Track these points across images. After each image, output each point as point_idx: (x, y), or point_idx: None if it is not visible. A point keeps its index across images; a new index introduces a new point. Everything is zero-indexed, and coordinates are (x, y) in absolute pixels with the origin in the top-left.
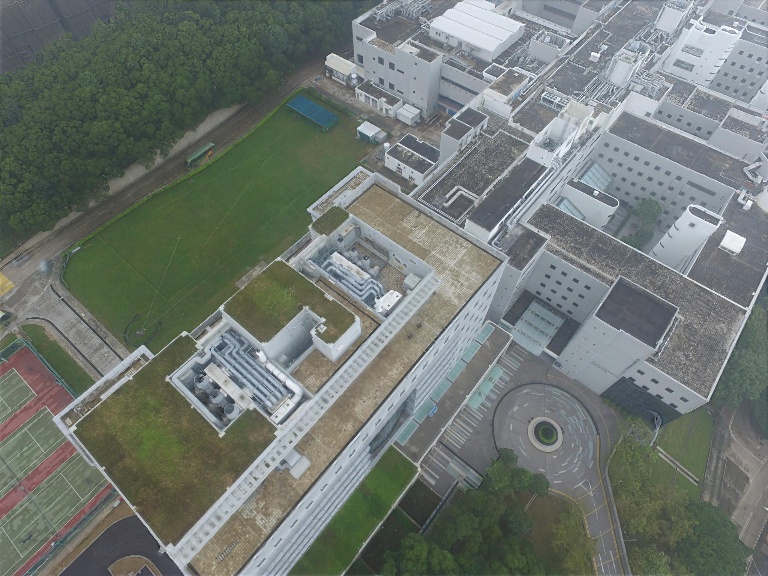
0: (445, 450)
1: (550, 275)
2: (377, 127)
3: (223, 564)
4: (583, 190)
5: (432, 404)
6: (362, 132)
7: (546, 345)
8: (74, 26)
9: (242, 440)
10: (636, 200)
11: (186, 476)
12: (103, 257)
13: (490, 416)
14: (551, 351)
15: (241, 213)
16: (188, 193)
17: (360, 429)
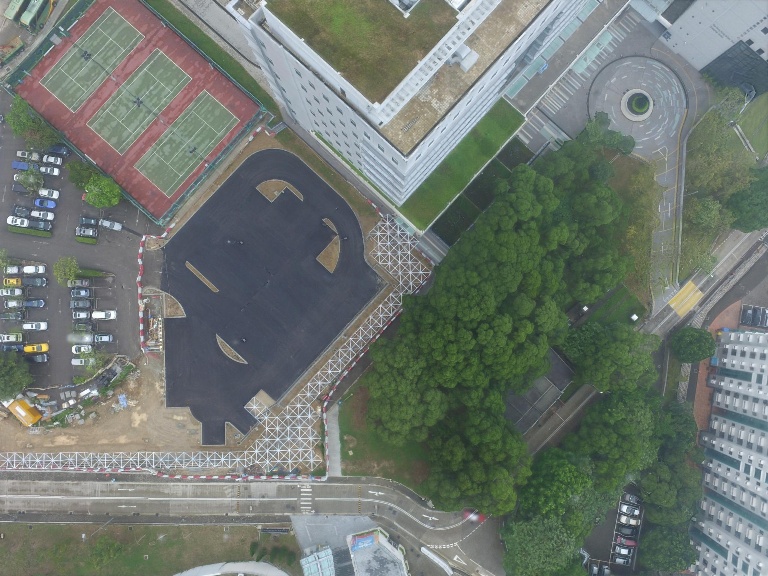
0: (541, 115)
1: None
2: None
3: (408, 134)
4: None
5: (542, 62)
6: None
7: (663, 11)
8: None
9: (427, 21)
10: None
11: (379, 50)
12: None
13: (588, 86)
14: (665, 19)
15: None
16: None
17: (522, 32)
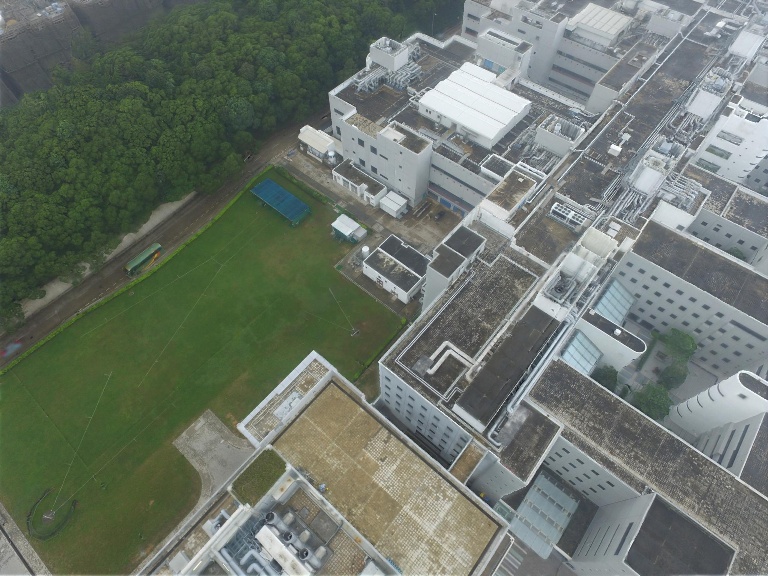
0: None
1: (562, 455)
2: (356, 222)
3: None
4: (602, 327)
5: None
6: (337, 229)
7: (556, 542)
8: (19, 81)
9: None
10: (663, 325)
11: None
12: (14, 402)
13: None
14: (562, 550)
15: (187, 339)
16: (126, 310)
17: None
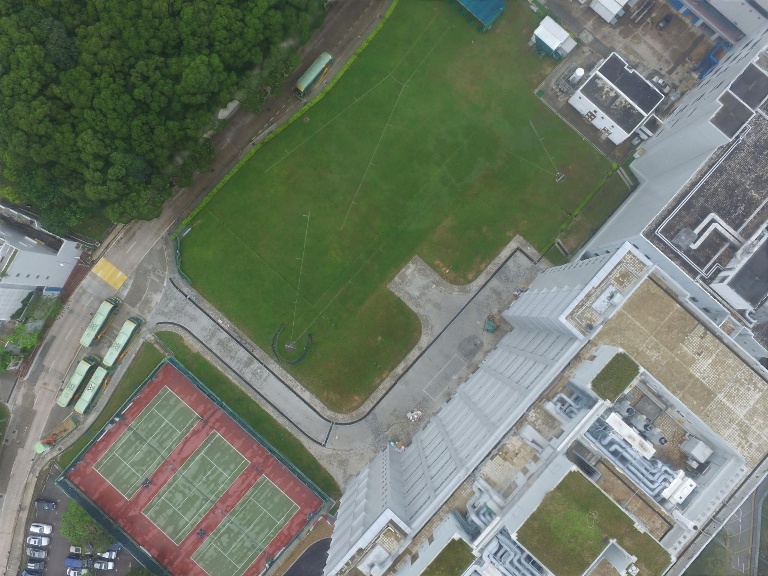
0: None
1: None
2: (564, 30)
3: None
4: None
5: None
6: (542, 40)
7: None
8: None
9: None
10: None
11: None
12: (221, 241)
13: None
14: None
15: (381, 179)
16: (306, 141)
17: None
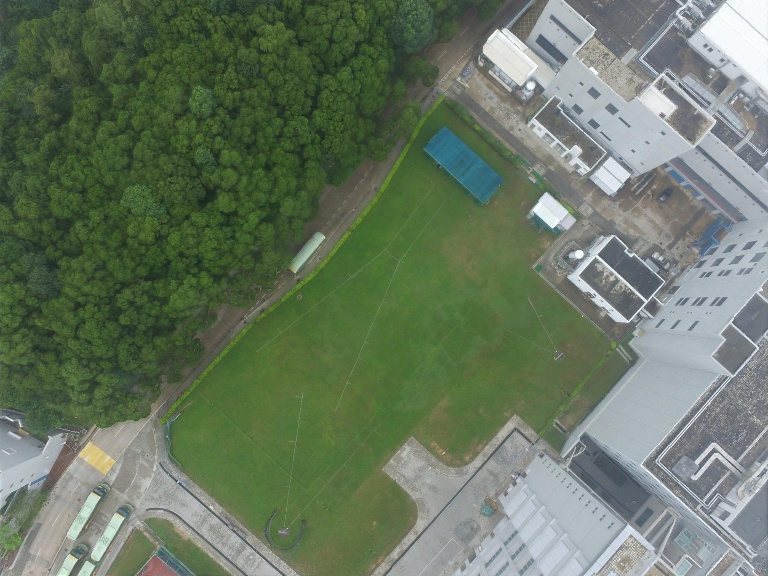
0: None
1: None
2: (563, 207)
3: None
4: None
5: None
6: (541, 218)
7: None
8: None
9: None
10: None
11: None
12: (212, 424)
13: None
14: (739, 571)
15: (376, 358)
16: (299, 319)
17: None
